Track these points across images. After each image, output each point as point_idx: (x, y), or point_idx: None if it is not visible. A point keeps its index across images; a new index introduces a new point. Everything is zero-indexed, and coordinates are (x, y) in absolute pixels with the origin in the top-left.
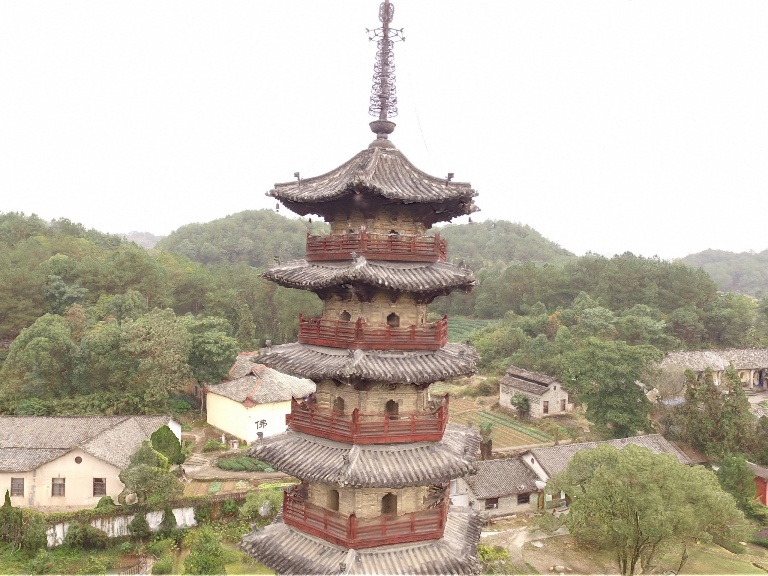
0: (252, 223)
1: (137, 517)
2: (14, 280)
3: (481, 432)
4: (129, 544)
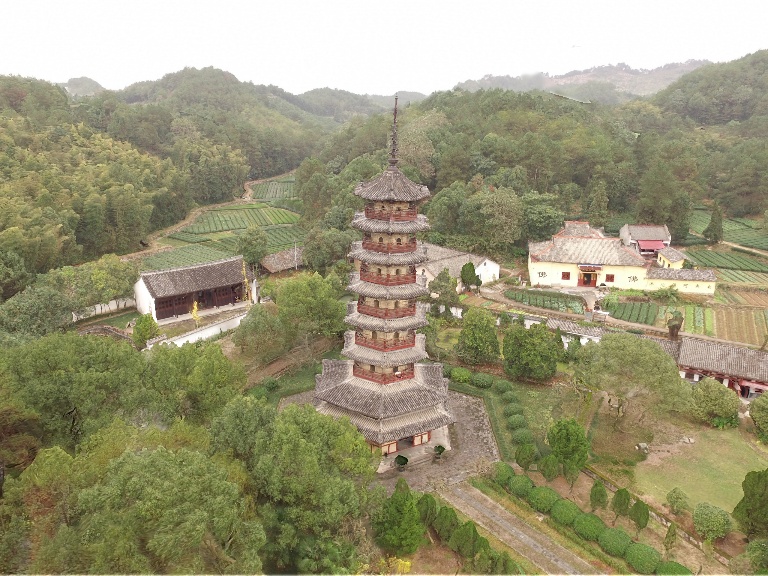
0: (761, 67)
1: (434, 305)
2: (452, 155)
3: (672, 318)
4: None
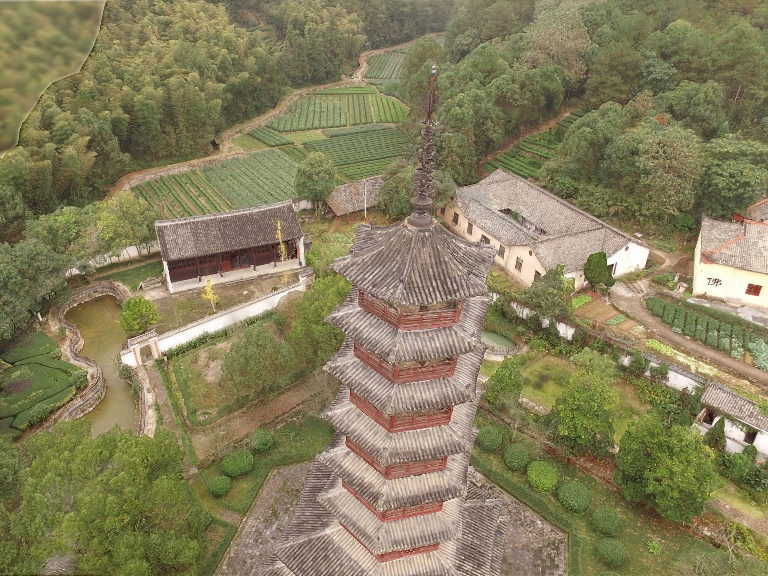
0: None
1: (533, 315)
2: (613, 55)
3: None
4: (522, 329)
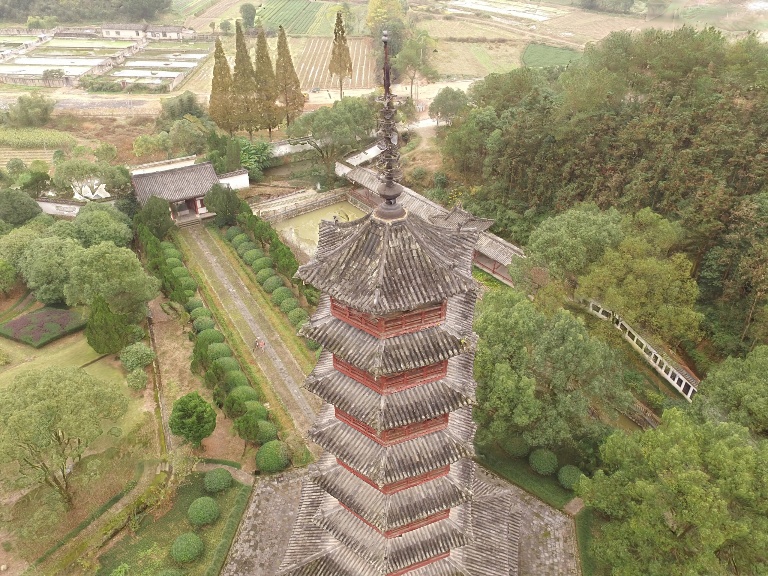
0: None
1: None
2: None
3: None
4: None
